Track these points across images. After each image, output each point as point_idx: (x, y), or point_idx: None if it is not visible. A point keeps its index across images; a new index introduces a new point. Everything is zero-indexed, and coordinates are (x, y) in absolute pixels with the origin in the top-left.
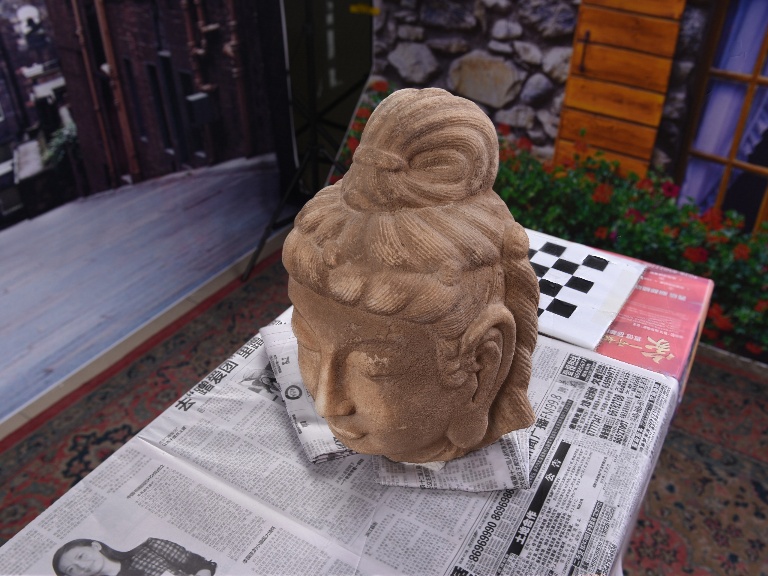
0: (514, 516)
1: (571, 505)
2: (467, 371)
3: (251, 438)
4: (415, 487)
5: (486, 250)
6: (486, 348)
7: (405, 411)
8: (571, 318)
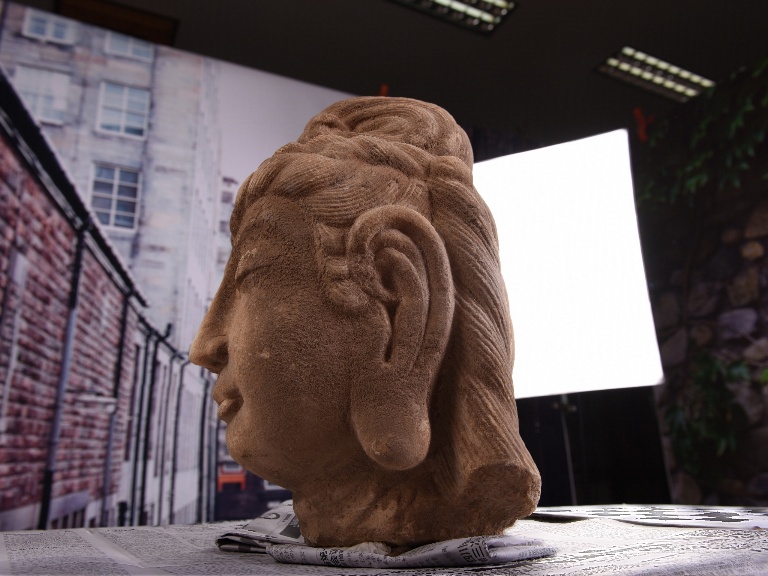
0: (431, 572)
1: (552, 567)
2: (364, 289)
3: (184, 538)
4: (316, 561)
5: (394, 151)
6: (390, 257)
7: (268, 325)
8: (734, 522)
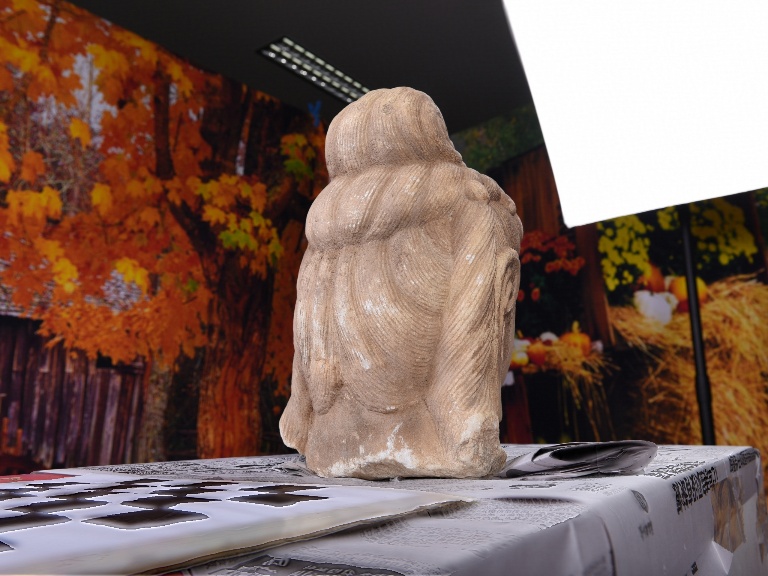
0: None
1: None
2: None
3: None
4: None
5: None
6: None
7: None
8: None
